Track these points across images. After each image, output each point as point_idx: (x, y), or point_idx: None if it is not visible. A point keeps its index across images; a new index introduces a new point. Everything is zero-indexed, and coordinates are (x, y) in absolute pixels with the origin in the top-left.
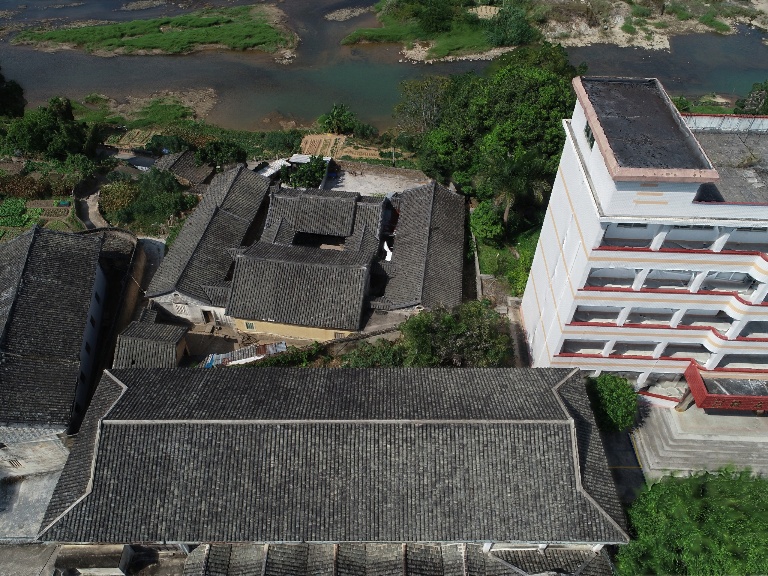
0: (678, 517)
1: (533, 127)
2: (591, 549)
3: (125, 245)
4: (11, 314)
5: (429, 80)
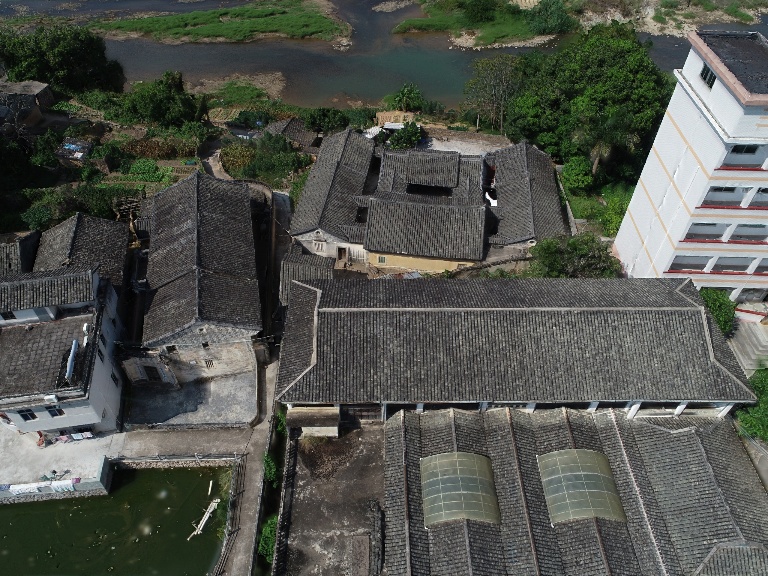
0: None
1: (622, 88)
2: (716, 416)
3: (258, 195)
4: (198, 240)
5: (499, 58)
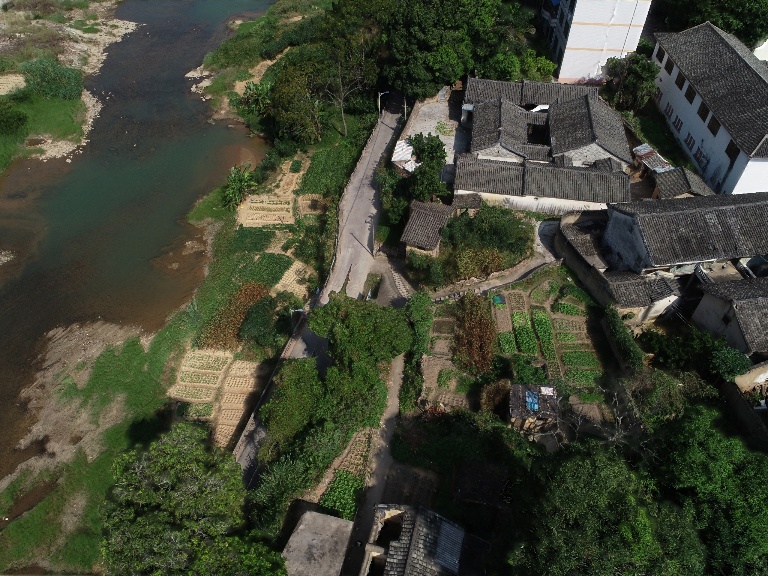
0: (746, 5)
1: None
2: None
3: (568, 229)
4: None
5: None
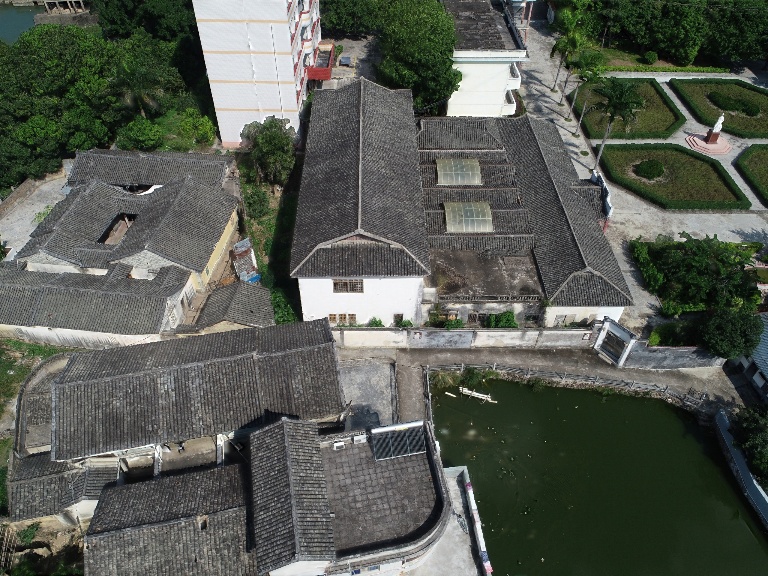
0: (414, 54)
1: None
2: None
3: (53, 378)
4: None
5: None
